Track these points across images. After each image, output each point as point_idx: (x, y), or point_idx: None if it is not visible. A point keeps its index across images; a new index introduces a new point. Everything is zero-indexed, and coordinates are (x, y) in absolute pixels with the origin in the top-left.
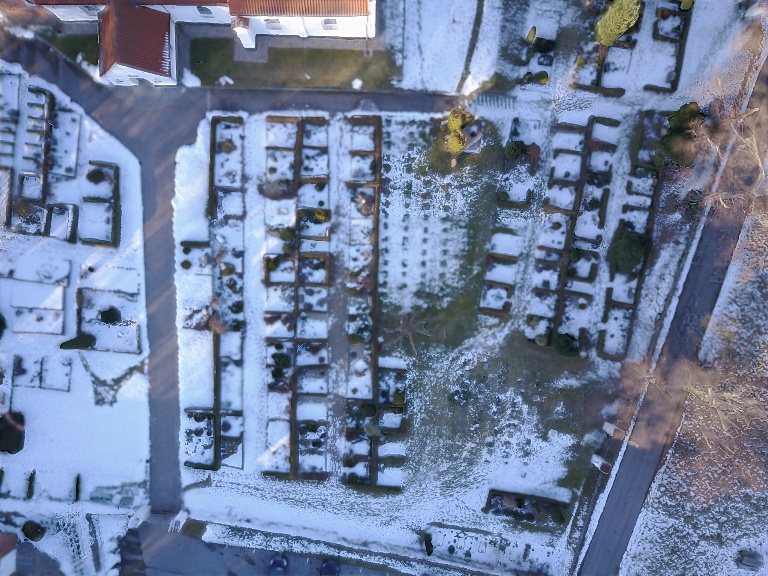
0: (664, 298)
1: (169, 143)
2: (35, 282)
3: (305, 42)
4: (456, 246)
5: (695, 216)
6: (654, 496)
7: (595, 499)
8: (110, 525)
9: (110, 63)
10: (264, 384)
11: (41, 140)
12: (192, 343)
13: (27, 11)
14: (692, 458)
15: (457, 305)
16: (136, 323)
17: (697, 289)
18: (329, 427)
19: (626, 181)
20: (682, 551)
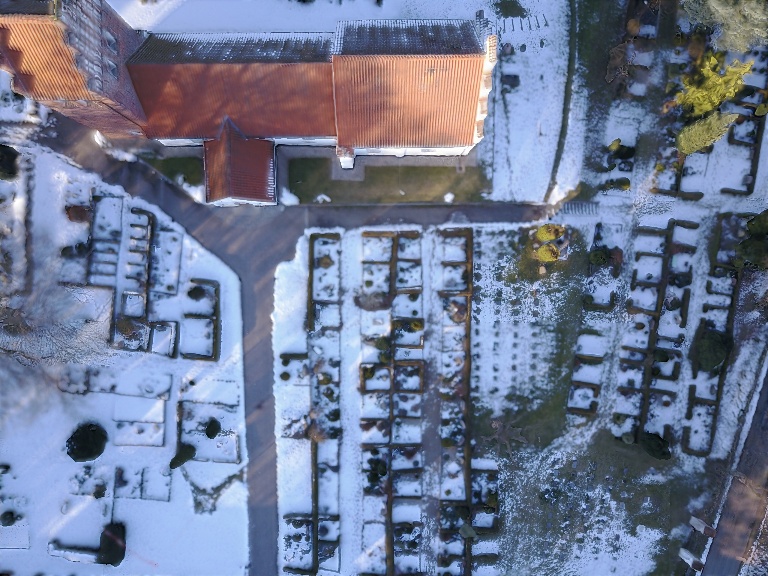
0: (746, 394)
1: (268, 260)
2: (137, 396)
3: (400, 160)
4: (545, 349)
5: None
6: None
7: None
8: None
9: (221, 194)
10: (360, 488)
11: (144, 260)
12: (290, 451)
13: (131, 137)
14: None
15: (546, 406)
16: (235, 433)
17: None
18: (423, 528)
19: (706, 281)
20: None
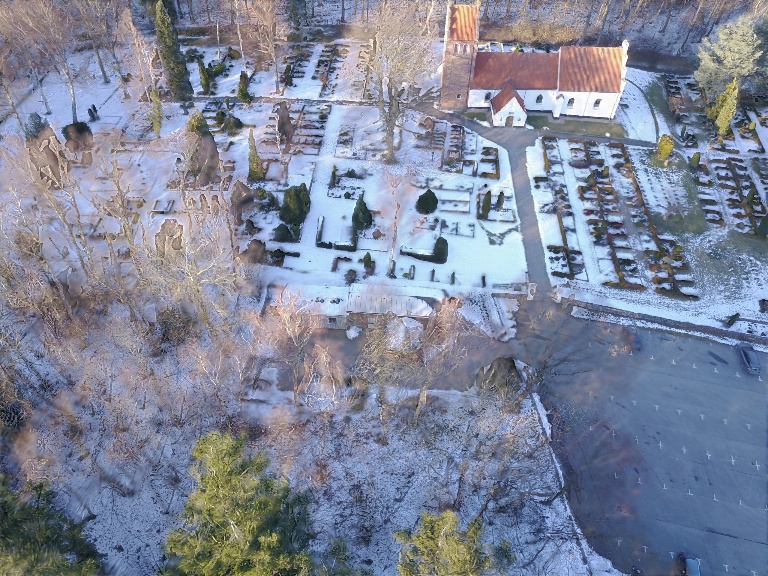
0: None
1: (521, 145)
2: (454, 191)
3: (581, 119)
4: (681, 193)
5: None
6: None
7: None
8: (507, 303)
9: None
10: (591, 242)
11: None
12: (545, 219)
13: (453, 104)
14: None
15: (693, 215)
16: (511, 210)
17: None
18: (637, 265)
19: (759, 180)
20: None
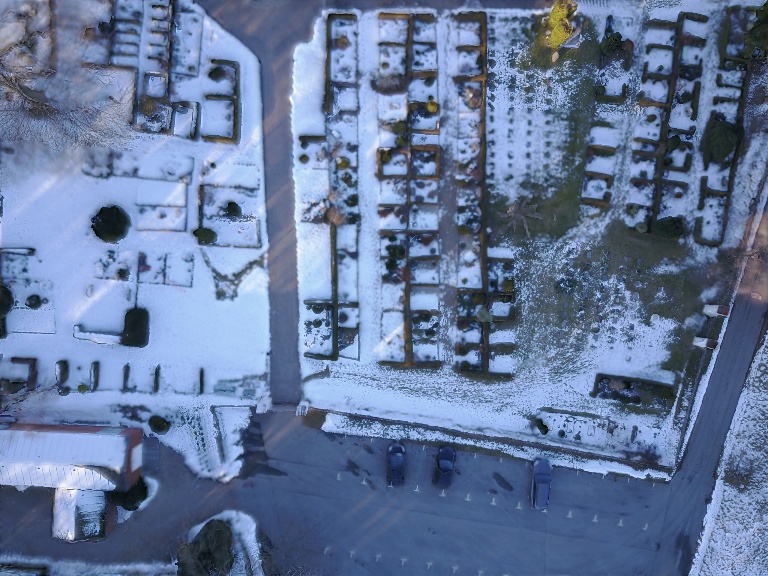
0: (757, 184)
1: (287, 41)
2: (159, 180)
3: None
4: (558, 138)
5: None
6: (754, 375)
7: (698, 380)
8: (233, 417)
9: None
10: (378, 276)
11: (165, 41)
12: (310, 236)
13: None
14: None
15: (561, 195)
16: (256, 218)
17: None
18: (441, 317)
19: (716, 74)
20: None
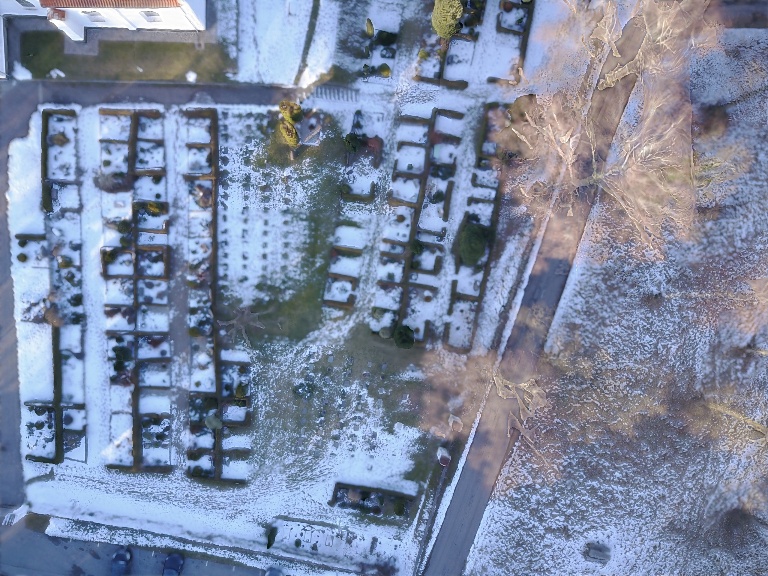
0: (508, 290)
1: (1, 136)
2: None
3: (136, 35)
4: (297, 239)
5: (539, 208)
6: (501, 489)
7: (442, 492)
8: None
9: None
10: (106, 377)
11: None
12: (31, 336)
13: None
14: (537, 450)
15: (299, 298)
16: None
17: (542, 281)
18: (173, 420)
19: (471, 173)
20: (528, 544)
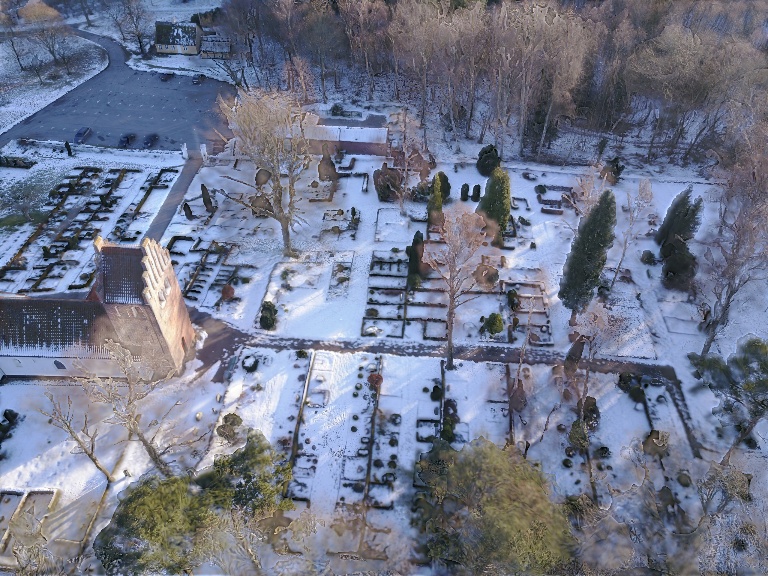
0: None
1: None
2: None
3: None
4: None
5: None
6: None
7: None
8: None
9: None
10: None
11: None
12: None
13: None
14: None
15: None
16: None
17: None
18: None
19: None
20: None
